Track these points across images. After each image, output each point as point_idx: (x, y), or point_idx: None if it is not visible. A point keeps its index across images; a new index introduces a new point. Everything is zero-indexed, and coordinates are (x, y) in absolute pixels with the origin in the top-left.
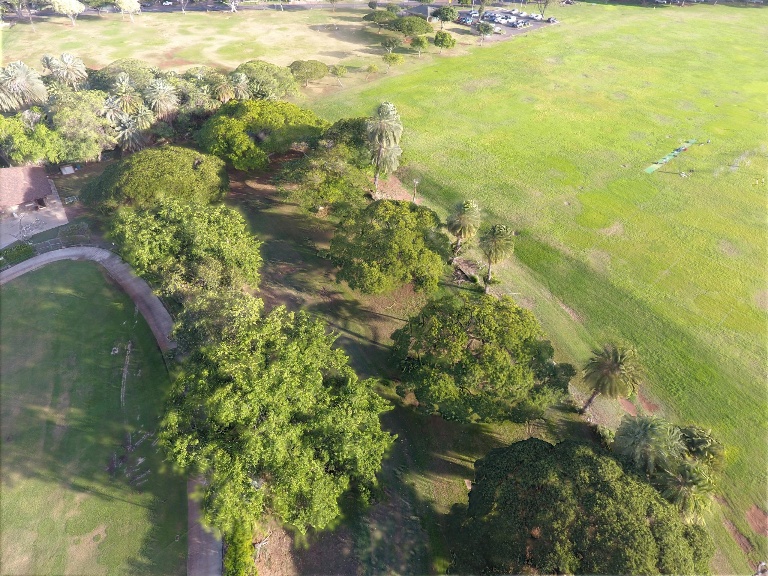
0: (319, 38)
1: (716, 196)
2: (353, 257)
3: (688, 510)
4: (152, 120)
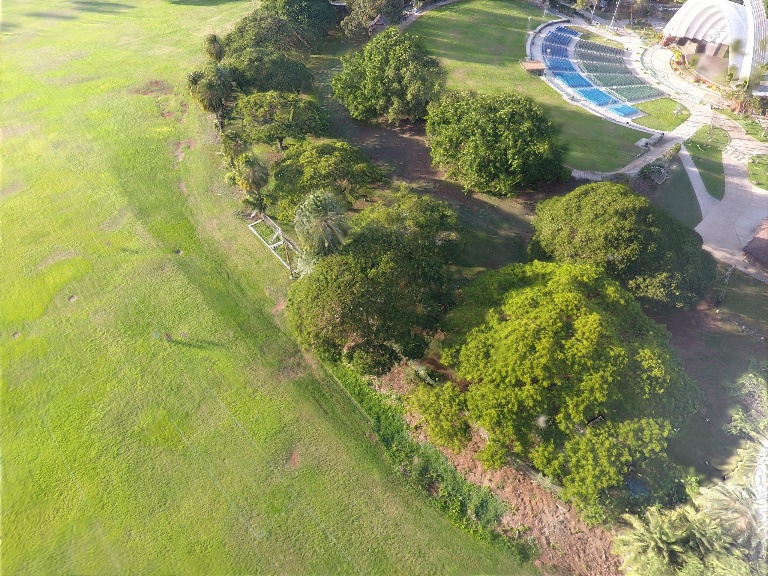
0: None
1: None
2: None
3: None
4: None
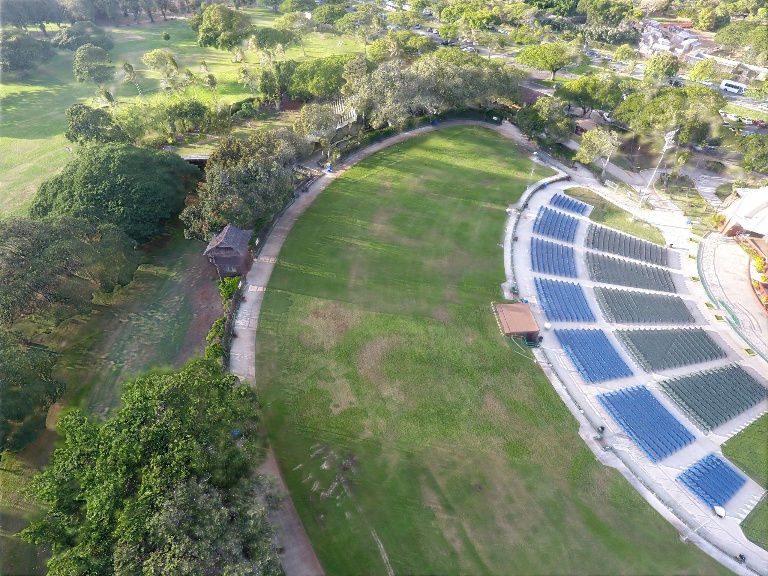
0: None
1: None
2: None
3: None
4: None
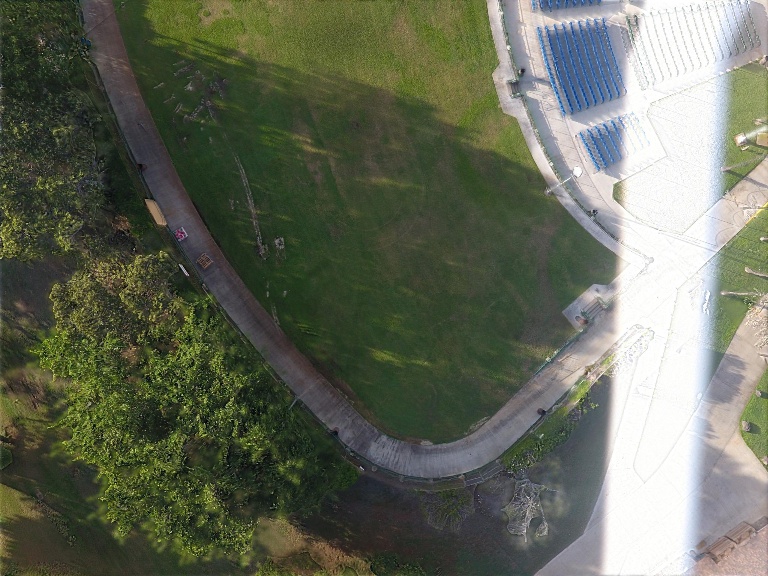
0: None
1: None
2: None
3: None
4: None
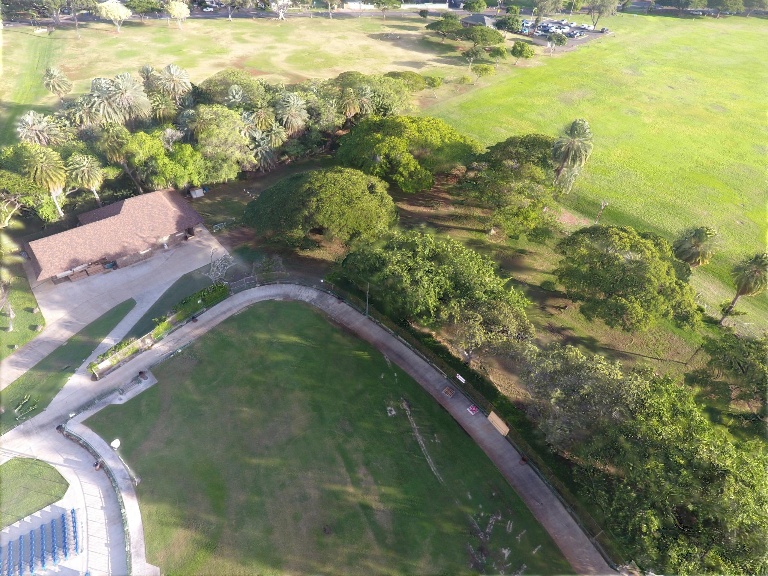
0: (384, 47)
1: None
2: (599, 291)
3: None
4: (284, 137)
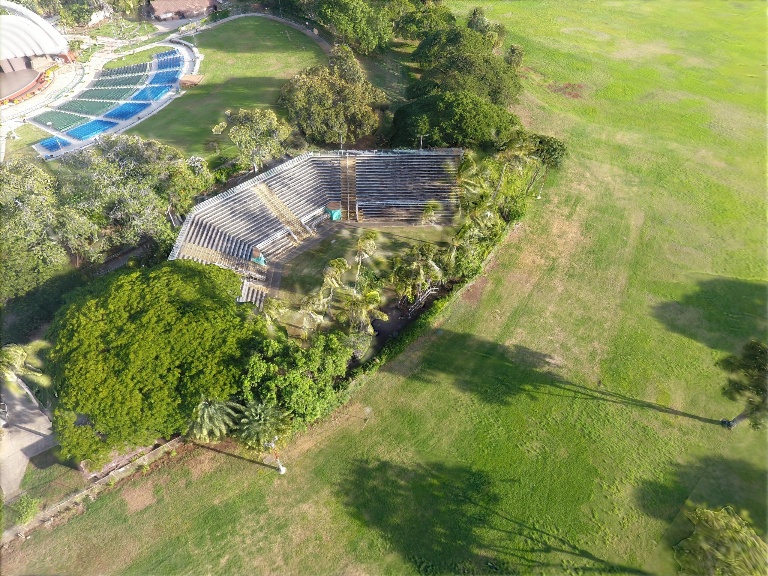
0: None
1: (568, 5)
2: None
3: (487, 37)
4: None
